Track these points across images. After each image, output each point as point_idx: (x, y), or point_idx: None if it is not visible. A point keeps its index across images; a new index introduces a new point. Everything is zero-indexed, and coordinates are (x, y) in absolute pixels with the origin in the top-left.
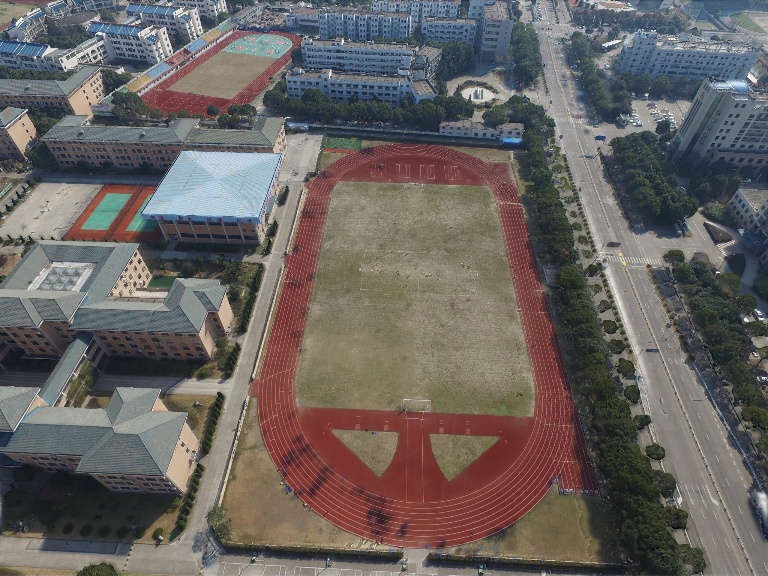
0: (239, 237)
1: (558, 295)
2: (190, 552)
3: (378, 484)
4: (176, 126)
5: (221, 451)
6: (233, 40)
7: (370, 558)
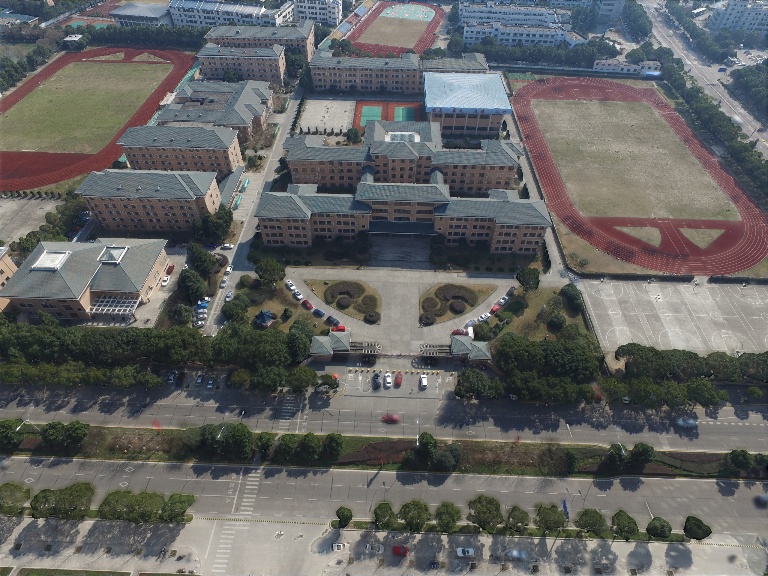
0: (485, 129)
1: (729, 162)
2: (560, 278)
3: (659, 250)
4: (409, 57)
5: (548, 236)
6: (384, 8)
7: (673, 280)
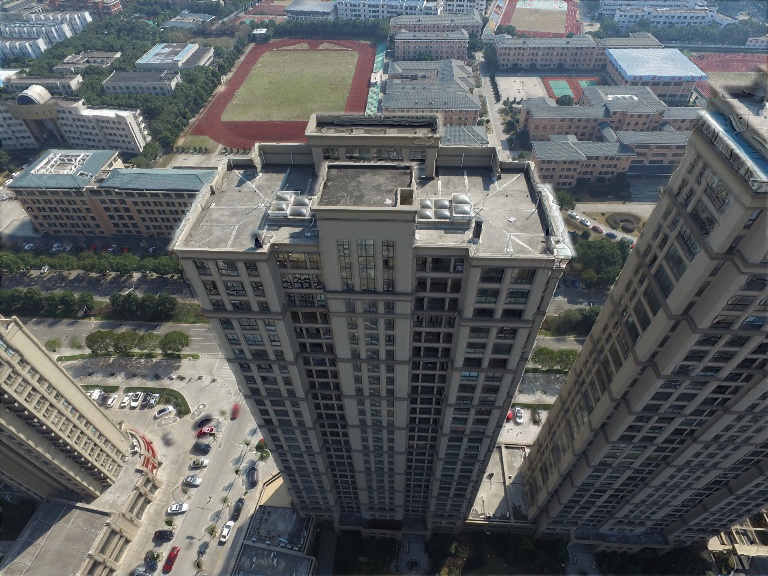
0: (675, 95)
1: None
2: None
3: None
4: None
5: None
6: (517, 1)
7: None
